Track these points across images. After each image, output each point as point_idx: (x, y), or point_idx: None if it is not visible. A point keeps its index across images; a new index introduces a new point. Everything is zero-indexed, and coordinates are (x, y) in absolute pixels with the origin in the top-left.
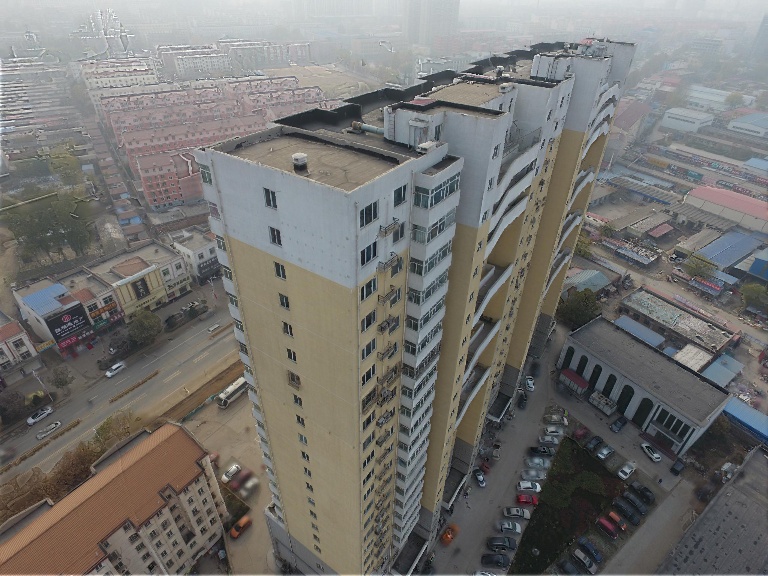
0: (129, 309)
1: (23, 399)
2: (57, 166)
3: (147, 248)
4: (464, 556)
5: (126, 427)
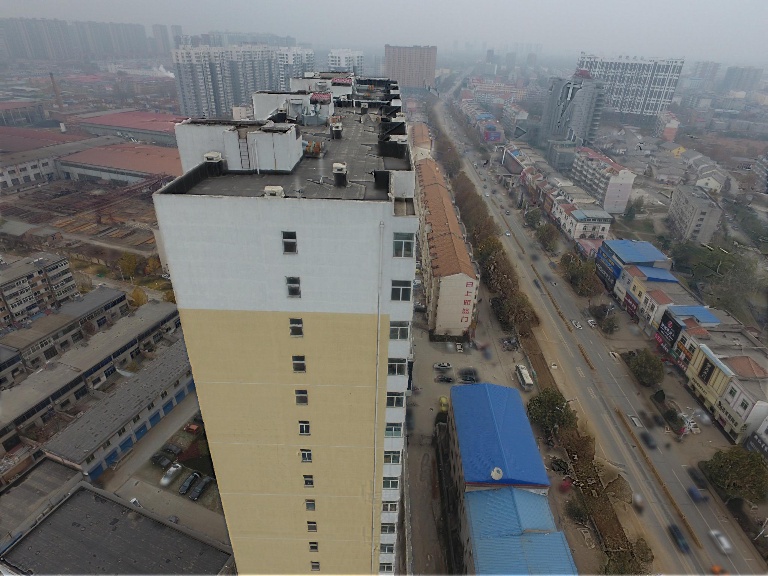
0: None
1: (603, 312)
2: None
3: None
4: None
5: (526, 316)
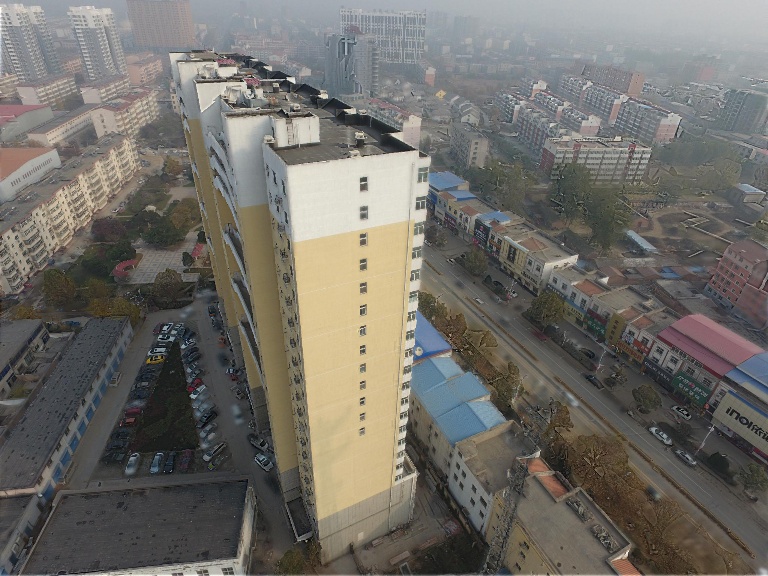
0: (502, 259)
1: (434, 232)
2: (762, 227)
3: (565, 253)
4: (208, 344)
5: None
